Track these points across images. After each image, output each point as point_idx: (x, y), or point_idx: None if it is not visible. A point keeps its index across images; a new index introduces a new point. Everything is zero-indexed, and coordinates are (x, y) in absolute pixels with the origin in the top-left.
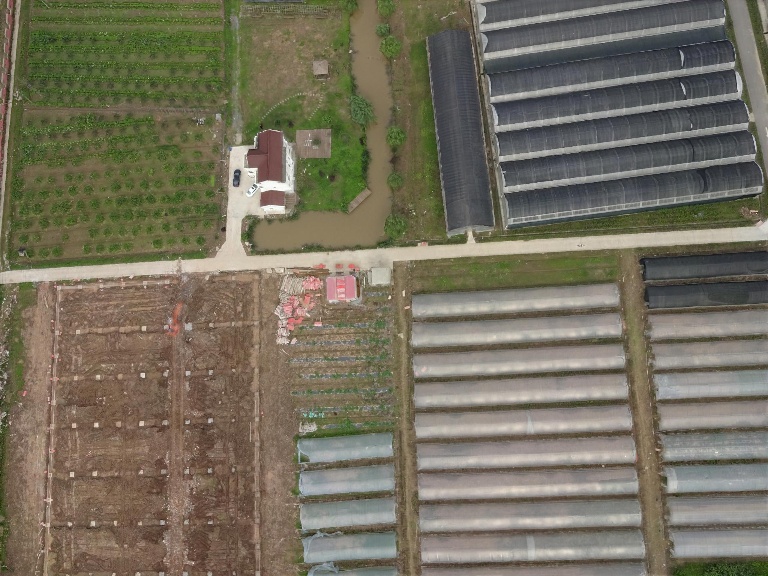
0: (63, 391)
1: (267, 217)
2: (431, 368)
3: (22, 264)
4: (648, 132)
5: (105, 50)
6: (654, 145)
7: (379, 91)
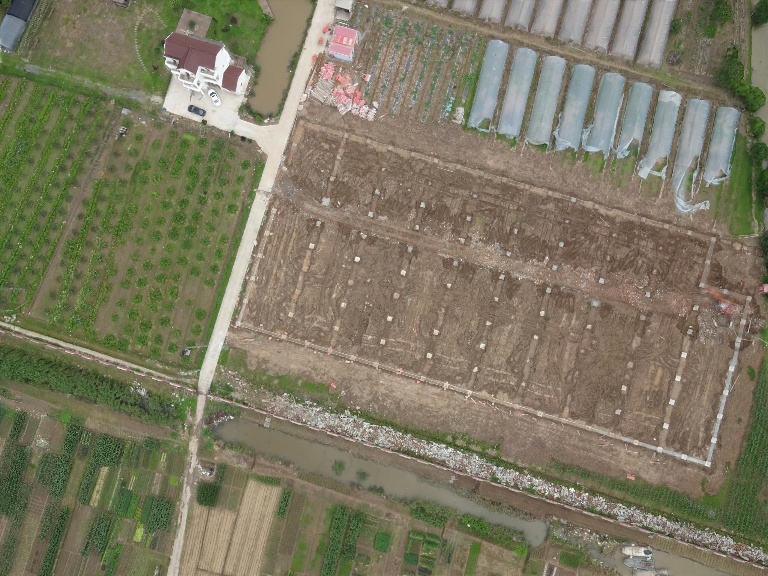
0: (345, 345)
1: (247, 95)
2: None
3: (198, 357)
4: None
5: (1, 209)
6: None
7: None
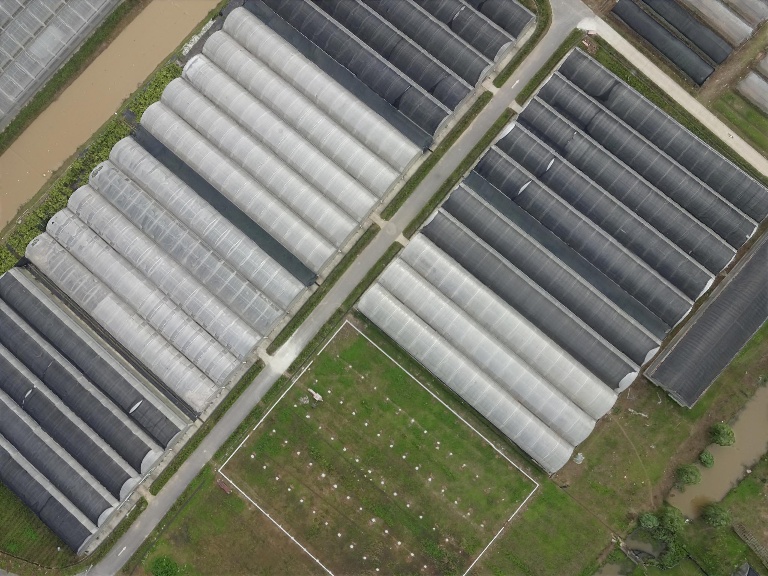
0: None
1: None
2: None
3: None
4: (609, 160)
5: None
6: (615, 147)
7: (760, 411)
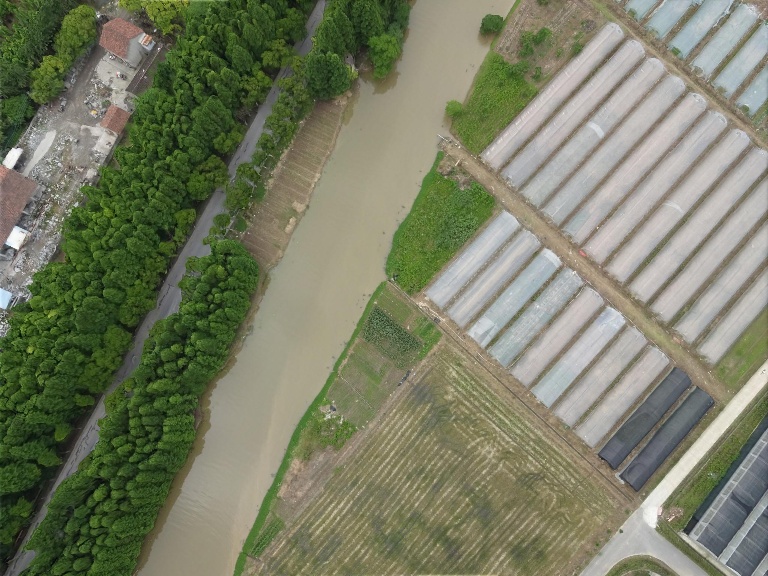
0: None
1: None
2: None
3: None
4: None
5: None
6: None
7: None
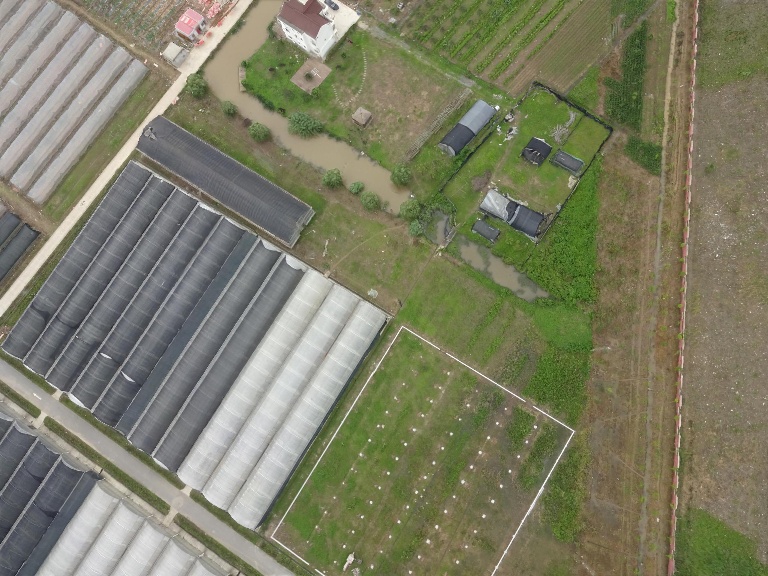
0: None
1: None
2: (98, 50)
3: None
4: (101, 303)
5: None
6: (90, 300)
7: (311, 151)
